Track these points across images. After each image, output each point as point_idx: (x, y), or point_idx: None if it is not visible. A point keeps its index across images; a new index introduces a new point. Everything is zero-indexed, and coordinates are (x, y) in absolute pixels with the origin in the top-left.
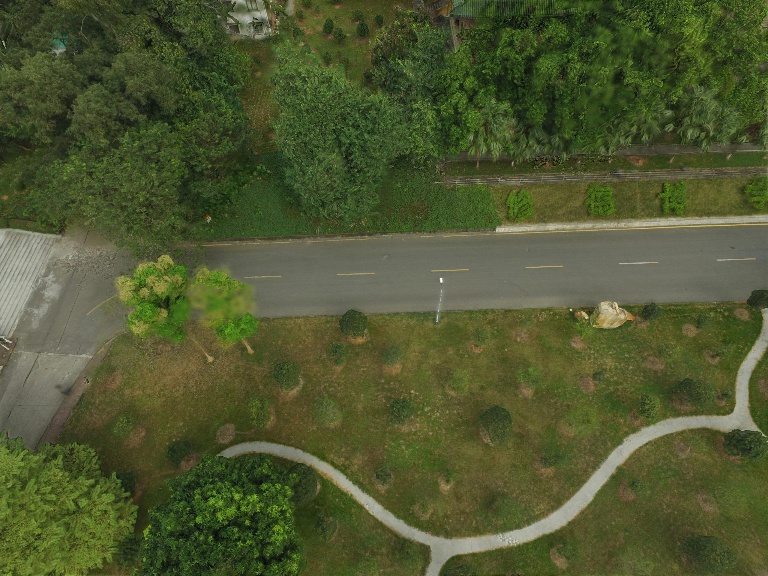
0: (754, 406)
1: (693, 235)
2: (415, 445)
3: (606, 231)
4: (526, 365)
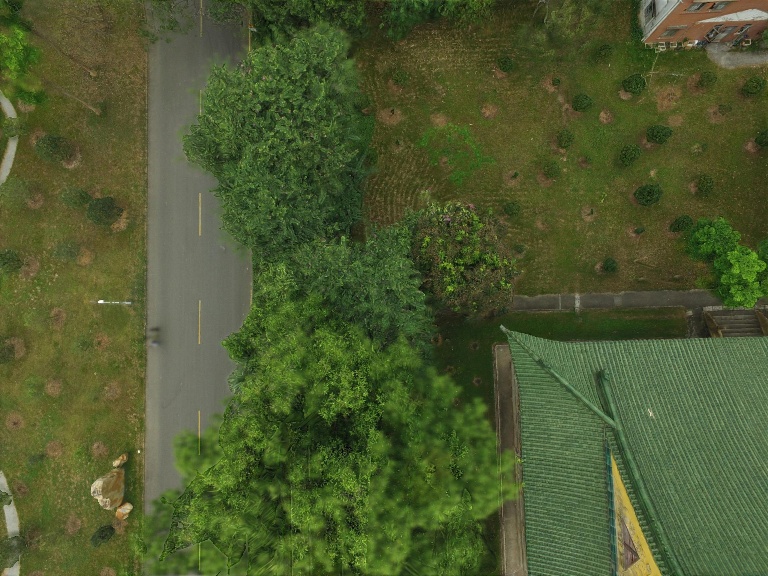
0: None
1: None
2: (6, 277)
3: None
4: (77, 391)
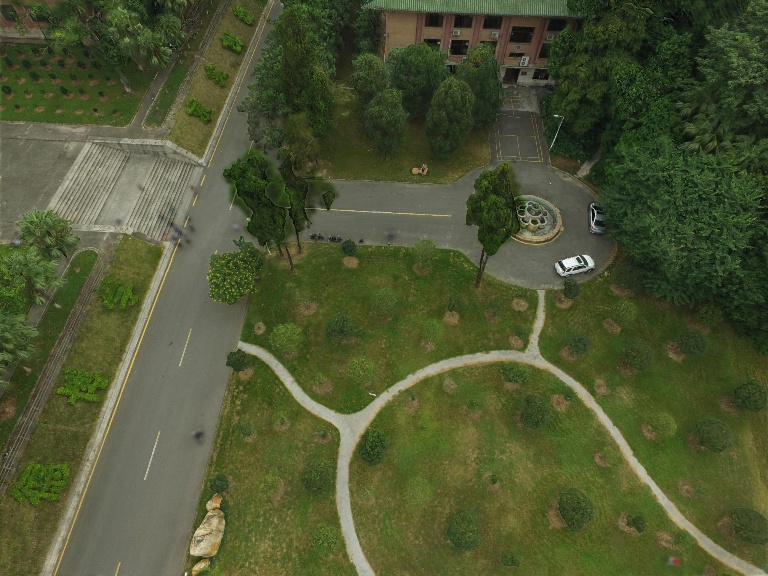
0: (335, 407)
1: (140, 376)
2: None
3: (92, 478)
4: None
